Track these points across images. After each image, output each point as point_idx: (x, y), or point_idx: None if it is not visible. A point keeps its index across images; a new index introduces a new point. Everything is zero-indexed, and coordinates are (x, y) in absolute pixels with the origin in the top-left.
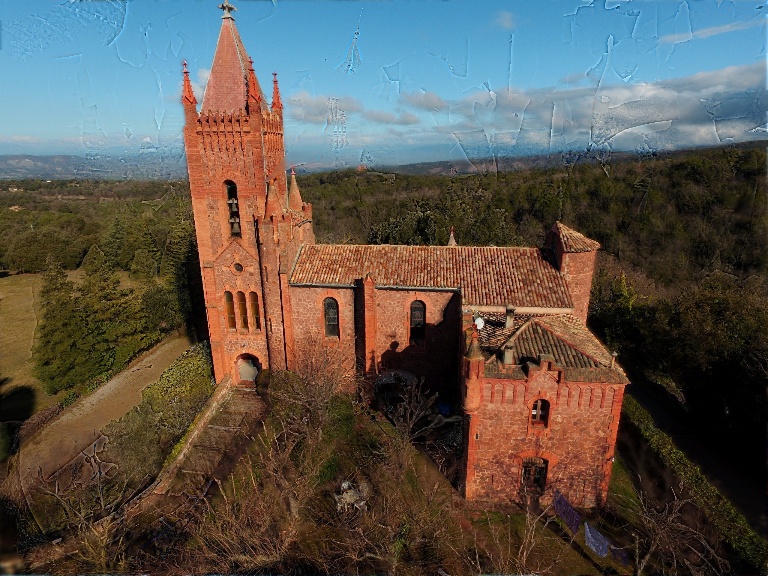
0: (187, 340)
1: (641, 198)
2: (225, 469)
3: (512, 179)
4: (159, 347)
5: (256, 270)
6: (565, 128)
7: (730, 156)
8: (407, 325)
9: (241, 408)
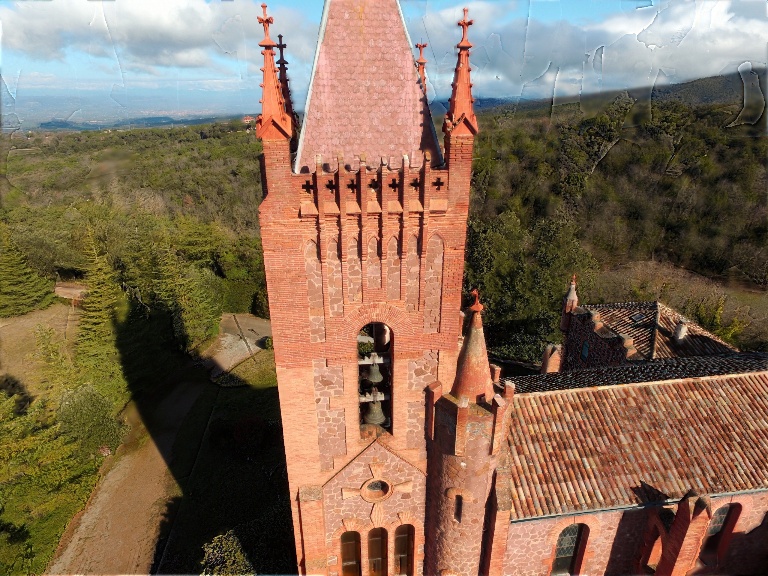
0: (142, 457)
1: (669, 186)
2: None
3: (507, 159)
4: (99, 483)
5: (417, 487)
6: (583, 101)
7: None
8: (700, 541)
9: None
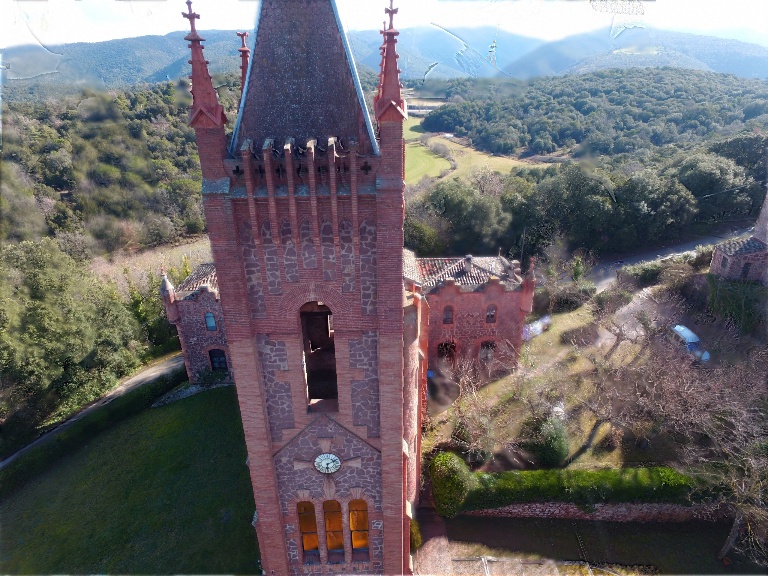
0: None
1: None
2: (545, 553)
3: None
4: None
5: None
6: None
7: (19, 128)
8: None
9: (447, 570)
